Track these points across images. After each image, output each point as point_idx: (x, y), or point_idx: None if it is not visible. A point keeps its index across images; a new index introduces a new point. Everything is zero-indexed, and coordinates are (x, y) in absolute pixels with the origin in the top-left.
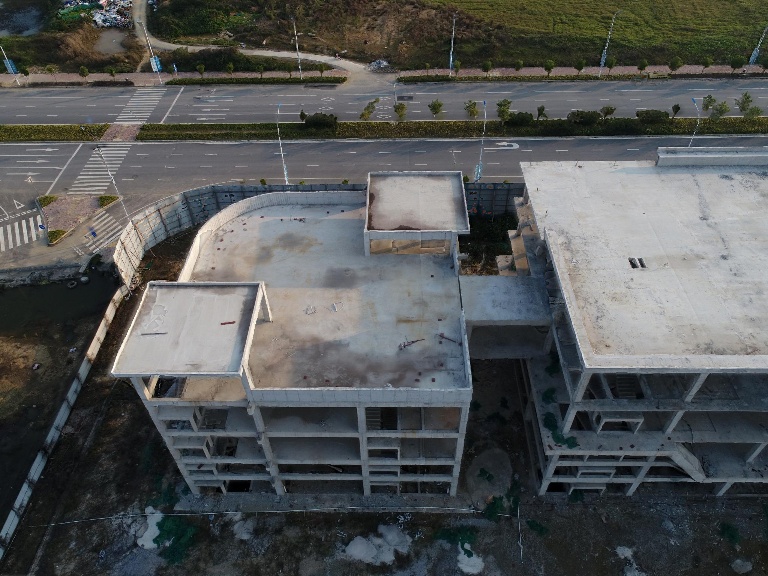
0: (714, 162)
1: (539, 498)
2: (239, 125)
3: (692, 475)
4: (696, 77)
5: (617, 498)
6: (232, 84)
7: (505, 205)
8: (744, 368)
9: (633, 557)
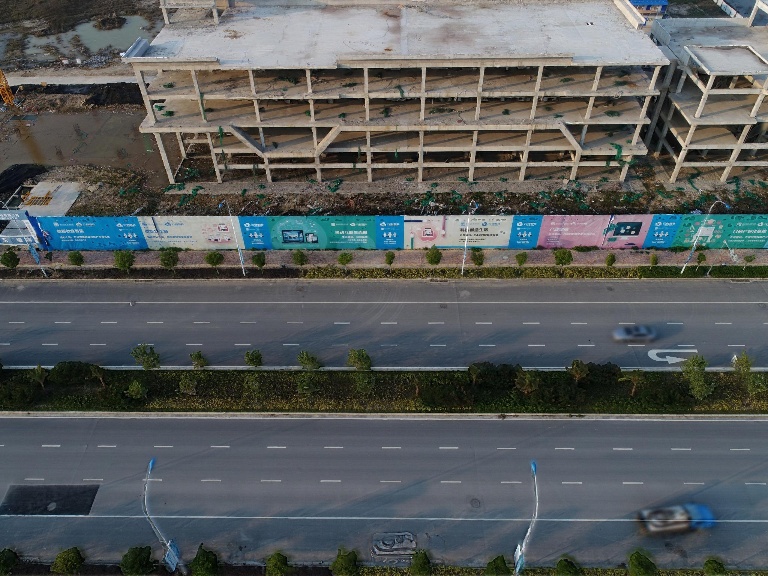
0: None
1: None
2: None
3: None
4: (295, 571)
5: None
6: None
7: (647, 237)
8: None
9: None
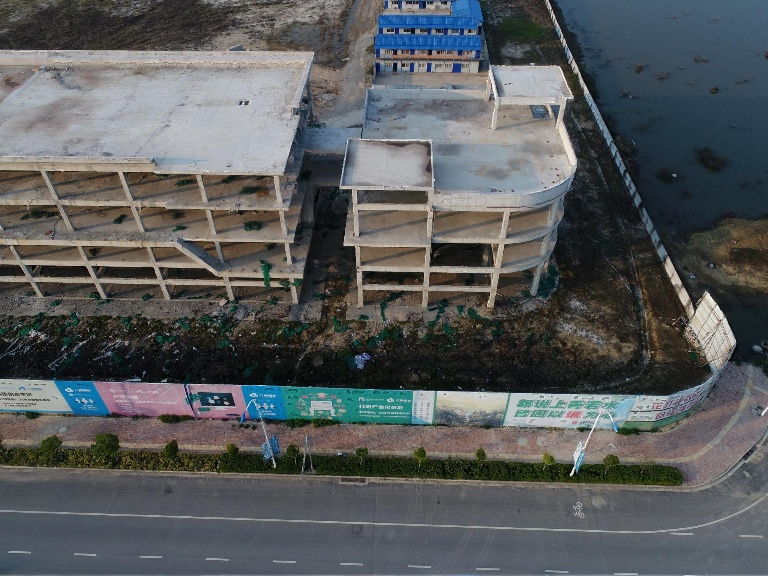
0: None
1: None
2: None
3: None
4: None
5: None
6: None
7: (250, 408)
8: None
9: None
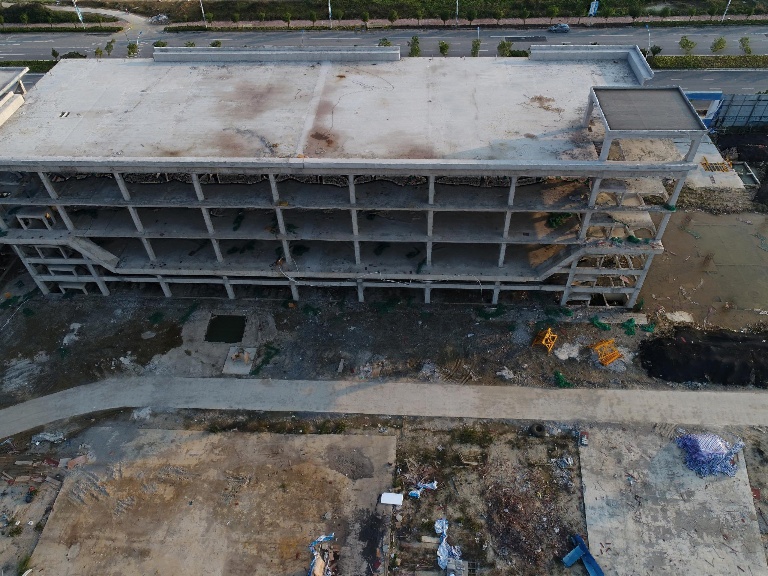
0: (194, 58)
1: (44, 297)
2: (9, 62)
3: (102, 265)
4: (413, 28)
5: (96, 297)
6: (27, 32)
7: None
8: (35, 160)
9: (79, 328)
